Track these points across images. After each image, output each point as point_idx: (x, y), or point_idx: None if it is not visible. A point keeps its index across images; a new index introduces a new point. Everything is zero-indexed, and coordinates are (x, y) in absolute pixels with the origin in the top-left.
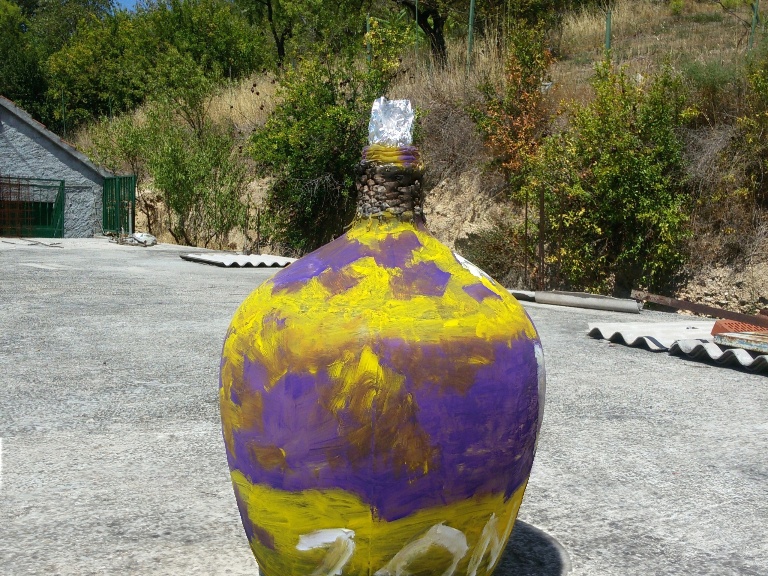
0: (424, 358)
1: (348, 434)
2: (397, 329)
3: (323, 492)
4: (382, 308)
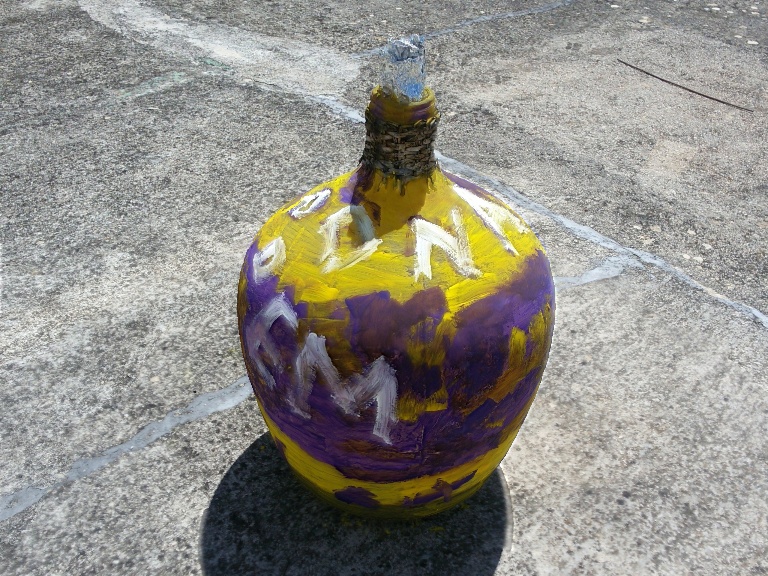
0: None
1: None
2: None
3: None
4: None
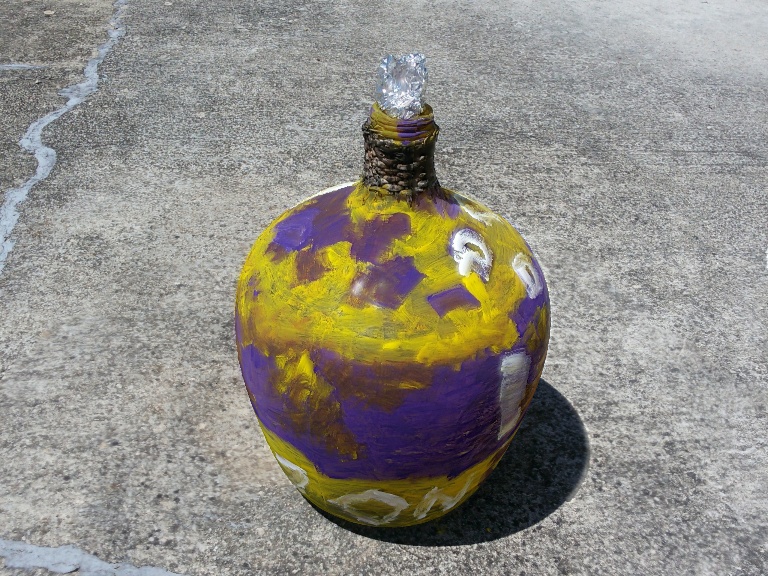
0: (354, 376)
1: (291, 413)
2: (337, 342)
3: (281, 439)
4: (332, 314)
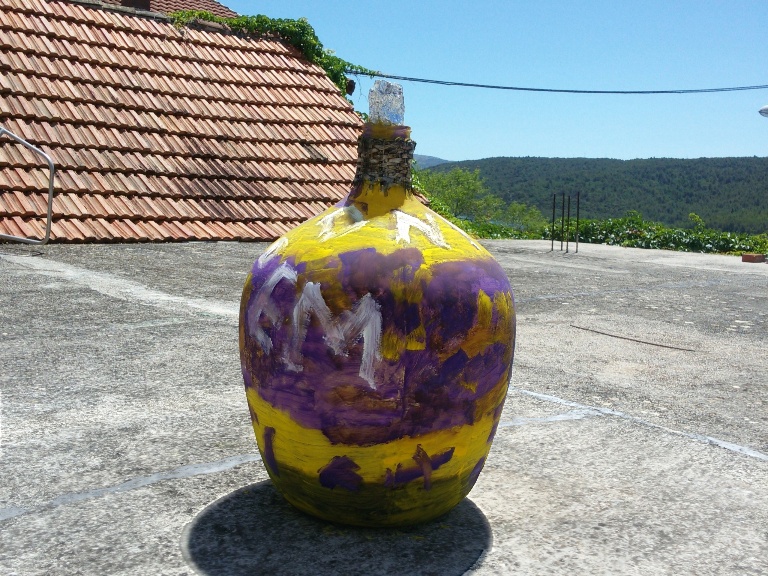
0: None
1: None
2: None
3: None
4: None
